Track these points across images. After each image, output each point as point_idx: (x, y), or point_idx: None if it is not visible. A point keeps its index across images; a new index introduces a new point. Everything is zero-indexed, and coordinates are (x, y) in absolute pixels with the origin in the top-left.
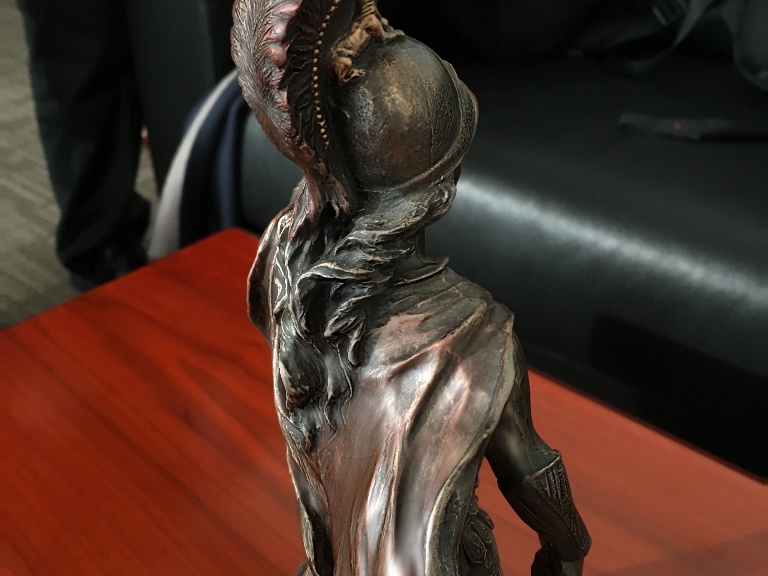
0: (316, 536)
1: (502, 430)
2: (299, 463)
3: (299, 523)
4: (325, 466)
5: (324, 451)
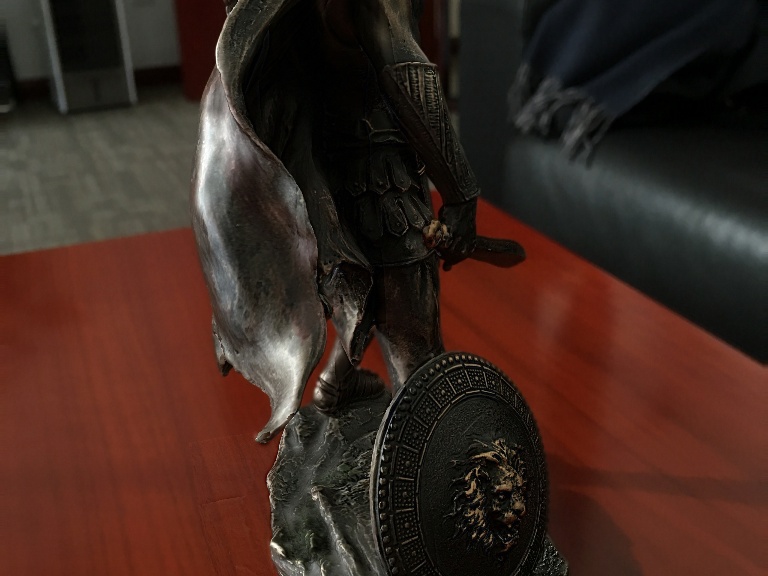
0: None
1: (371, 17)
2: None
3: None
4: None
5: None
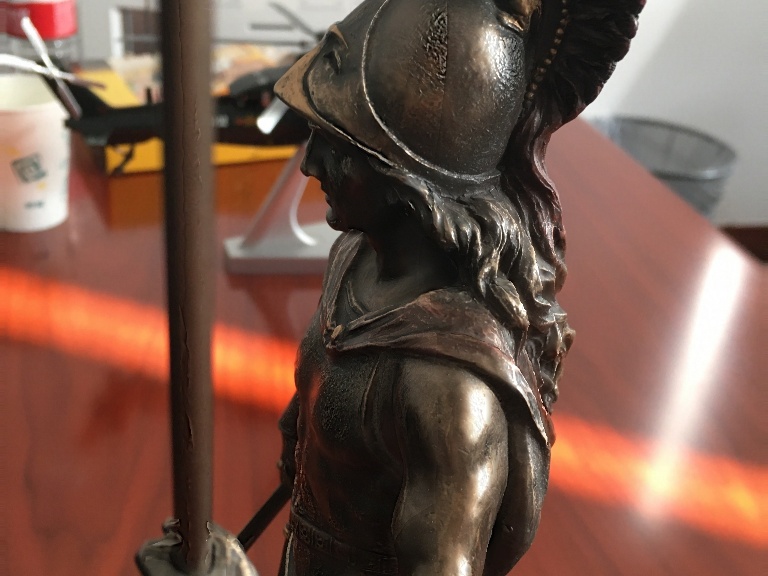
0: None
1: None
2: None
3: None
4: None
5: None
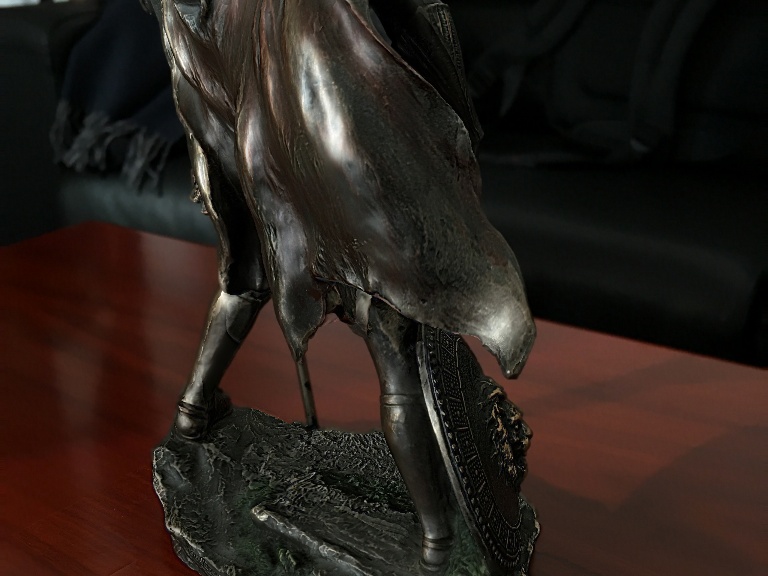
0: (211, 170)
1: None
2: (192, 76)
3: (193, 163)
4: (222, 26)
5: (220, 8)
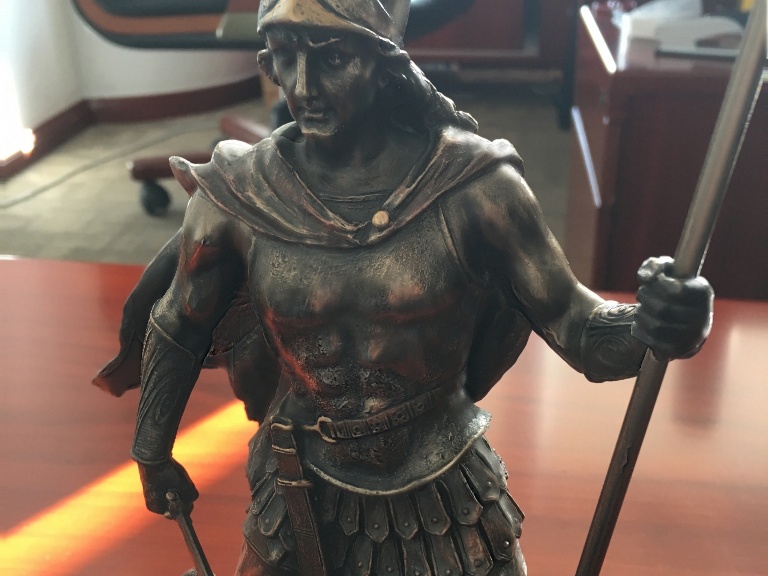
0: None
1: None
2: None
3: None
4: None
5: None
